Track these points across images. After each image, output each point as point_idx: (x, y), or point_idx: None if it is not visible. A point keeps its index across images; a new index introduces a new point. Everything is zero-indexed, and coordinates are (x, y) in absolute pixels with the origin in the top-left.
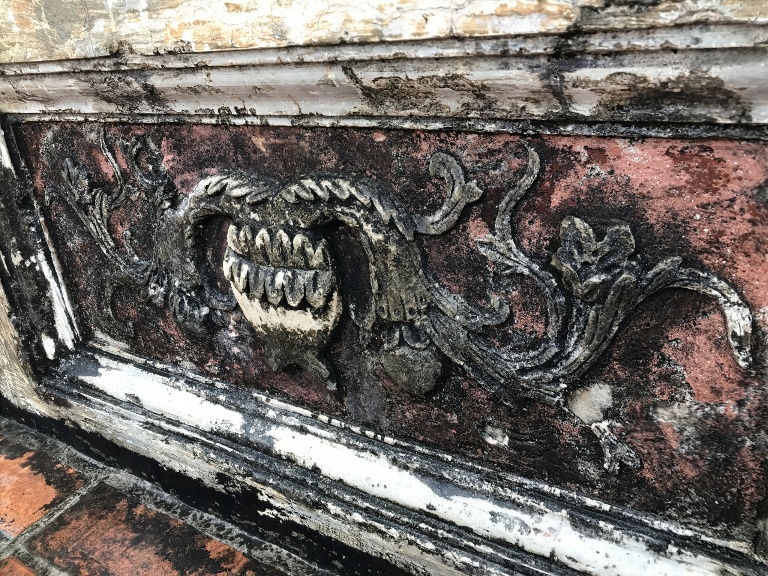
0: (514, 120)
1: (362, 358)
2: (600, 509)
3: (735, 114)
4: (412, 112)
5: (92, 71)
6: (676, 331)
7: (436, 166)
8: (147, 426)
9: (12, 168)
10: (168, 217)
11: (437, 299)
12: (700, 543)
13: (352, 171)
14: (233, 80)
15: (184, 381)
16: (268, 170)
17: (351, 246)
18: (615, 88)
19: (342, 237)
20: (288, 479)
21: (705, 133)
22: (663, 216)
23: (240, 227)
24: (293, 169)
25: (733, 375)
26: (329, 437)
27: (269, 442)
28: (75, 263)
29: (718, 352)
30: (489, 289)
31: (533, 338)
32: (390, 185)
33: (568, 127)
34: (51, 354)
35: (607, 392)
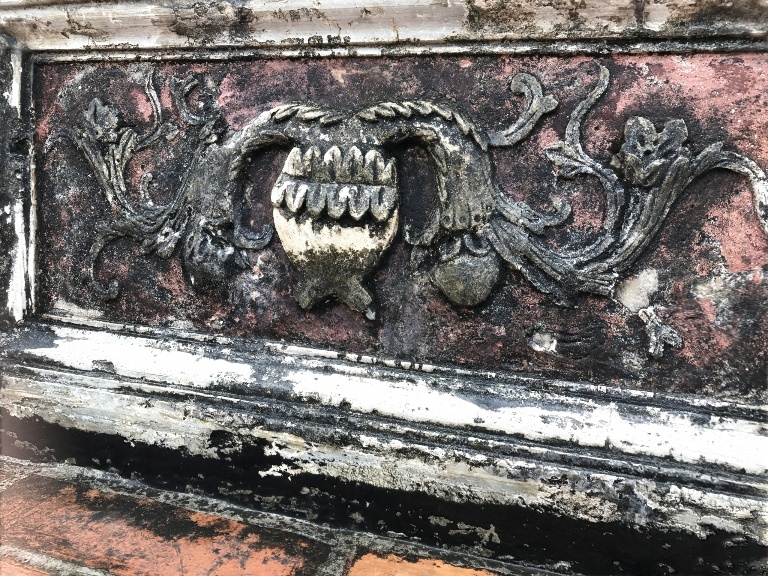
0: (593, 42)
1: (409, 281)
2: (645, 397)
3: (765, 26)
4: (507, 34)
5: None
6: (714, 210)
7: (518, 84)
8: (120, 392)
9: (18, 107)
10: (213, 150)
11: (501, 207)
12: (736, 411)
13: (432, 96)
14: (344, 2)
15: (176, 341)
16: (342, 100)
17: (417, 167)
18: (685, 3)
19: (409, 159)
20: (310, 420)
21: (740, 45)
22: (707, 112)
23: (304, 150)
24: (370, 98)
25: (759, 243)
26: (359, 373)
27: (287, 386)
28: (58, 218)
29: (747, 225)
30: (552, 193)
31: (590, 234)
32: (469, 105)
33: (637, 45)
34: None
35: (654, 276)
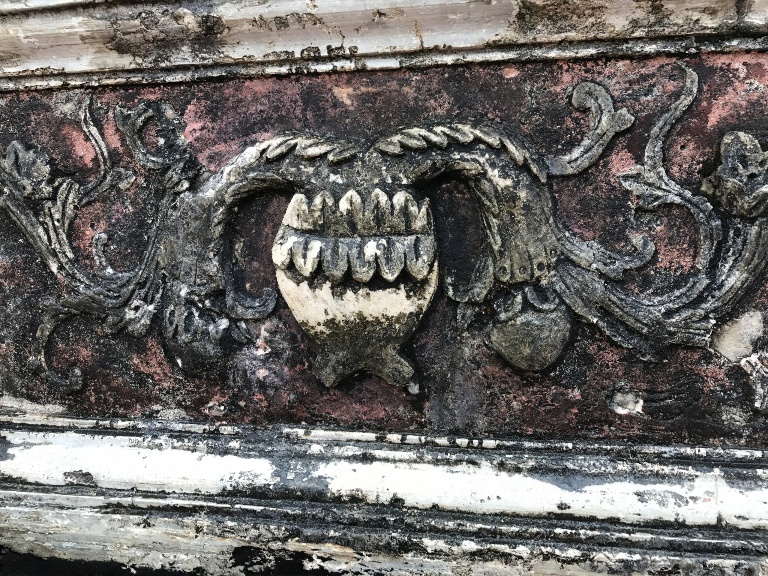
0: (677, 39)
1: (457, 344)
2: (752, 458)
3: None
4: (568, 35)
5: (122, 2)
6: None
7: (582, 96)
8: (108, 510)
9: None
10: (186, 201)
11: (568, 249)
12: None
13: (469, 116)
14: (350, 3)
15: (167, 436)
16: (350, 127)
17: (456, 206)
18: None
19: (445, 196)
20: (357, 524)
21: None
22: None
23: (309, 196)
24: (387, 122)
25: None
26: (407, 458)
27: (320, 484)
28: None
29: None
30: (629, 229)
31: (679, 275)
32: (518, 126)
33: (733, 41)
34: None
35: (758, 320)
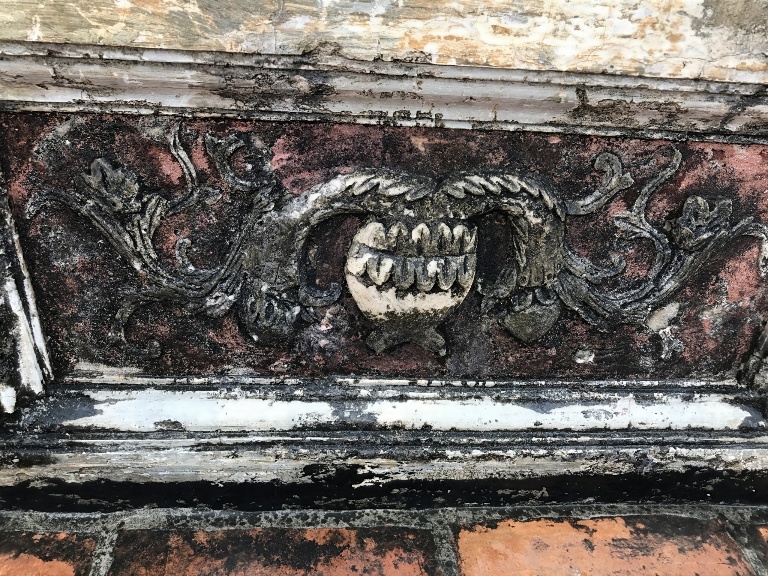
0: (676, 131)
1: (478, 322)
2: (652, 386)
3: None
4: (605, 123)
5: None
6: (731, 261)
7: (602, 163)
8: (199, 448)
9: None
10: (273, 220)
11: (569, 264)
12: (709, 387)
13: (516, 167)
14: (450, 90)
15: (240, 389)
16: (421, 168)
17: (494, 230)
18: (767, 117)
19: (487, 223)
20: (399, 445)
21: None
22: (748, 192)
23: (385, 224)
24: (451, 166)
25: (754, 282)
26: (432, 397)
27: (371, 419)
28: (63, 286)
29: (749, 270)
30: (611, 251)
31: (636, 281)
32: (551, 178)
33: (711, 137)
34: (11, 406)
35: (676, 308)
